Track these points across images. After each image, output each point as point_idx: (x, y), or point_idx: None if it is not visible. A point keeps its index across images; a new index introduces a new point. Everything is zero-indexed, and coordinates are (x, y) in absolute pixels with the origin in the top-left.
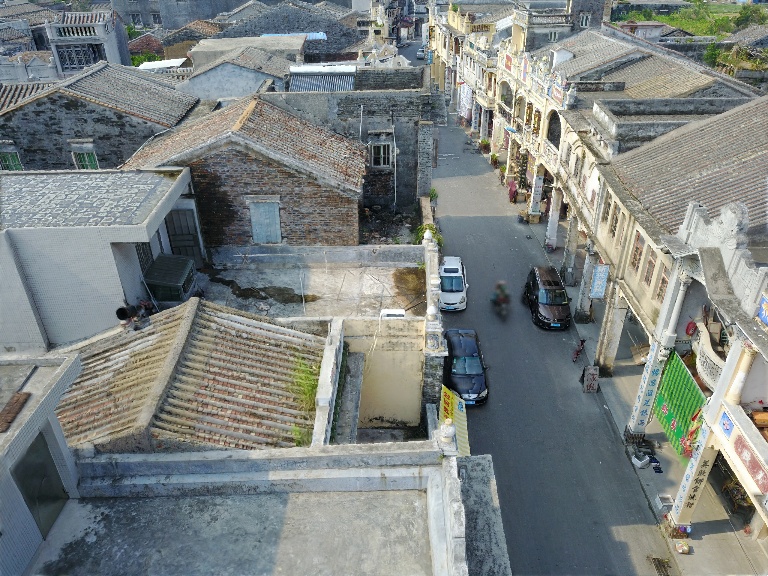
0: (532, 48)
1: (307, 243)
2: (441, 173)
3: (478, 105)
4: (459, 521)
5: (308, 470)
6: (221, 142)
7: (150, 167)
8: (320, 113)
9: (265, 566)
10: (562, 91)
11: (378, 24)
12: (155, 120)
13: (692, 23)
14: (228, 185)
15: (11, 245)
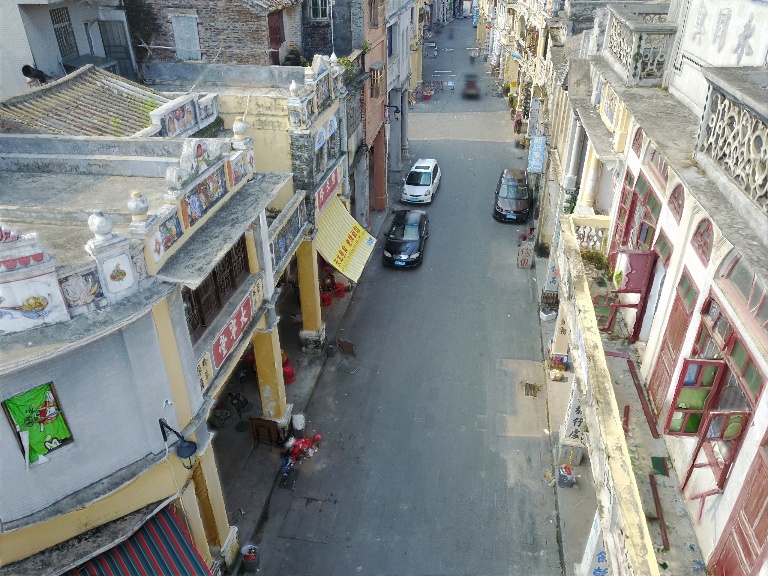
0: None
1: (224, 61)
2: (456, 109)
3: None
4: (188, 143)
5: (120, 156)
6: None
7: None
8: None
9: (54, 201)
10: None
11: None
12: None
13: None
14: None
15: None
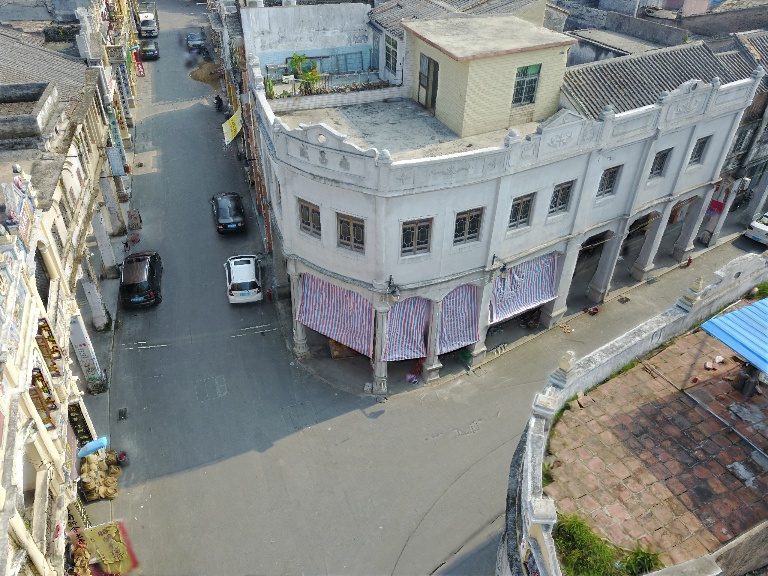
0: None
1: None
2: None
3: None
4: None
5: None
6: None
7: None
8: None
9: None
10: None
11: None
12: None
13: None
14: None
15: None
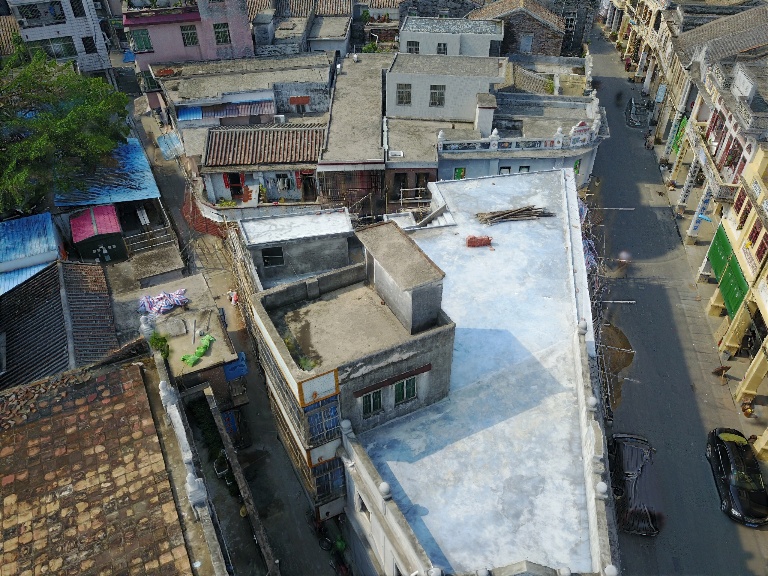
0: None
1: (540, 54)
2: None
3: (613, 7)
4: None
5: (554, 101)
6: (518, 11)
7: (490, 19)
8: (547, 2)
9: (545, 115)
10: None
11: None
12: (477, 2)
13: None
14: (516, 28)
15: (460, 39)
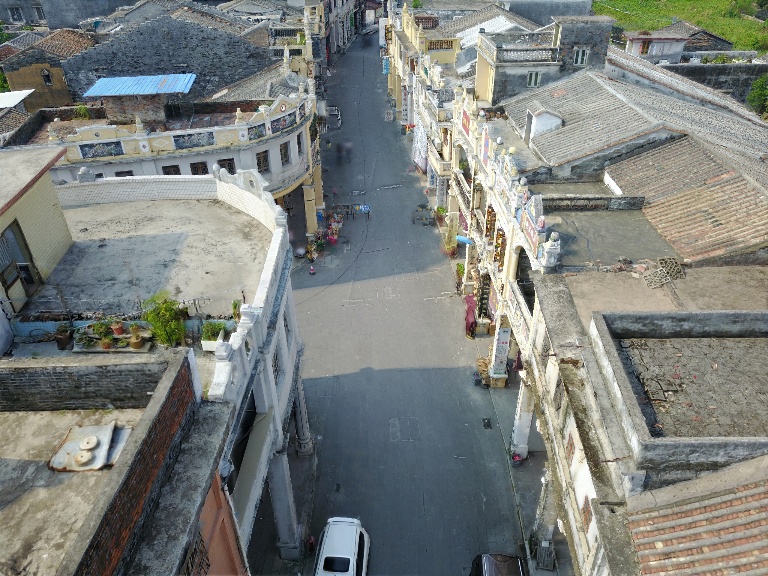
0: (503, 95)
1: None
2: (375, 268)
3: None
4: None
5: None
6: None
7: None
8: None
9: None
10: (536, 234)
11: (304, 35)
12: None
13: (707, 1)
14: None
15: None
